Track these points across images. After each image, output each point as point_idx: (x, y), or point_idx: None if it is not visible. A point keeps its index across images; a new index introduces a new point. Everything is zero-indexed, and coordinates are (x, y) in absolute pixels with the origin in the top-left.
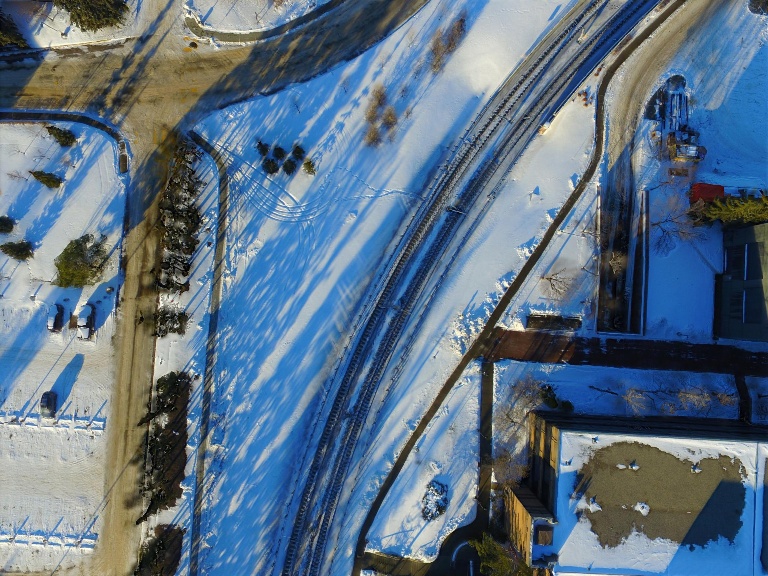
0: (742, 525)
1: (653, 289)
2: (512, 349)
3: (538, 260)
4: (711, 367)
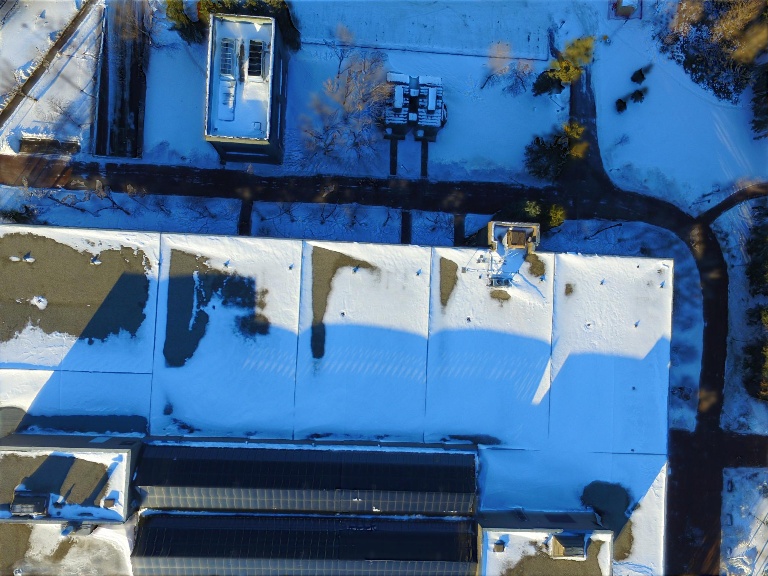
0: (145, 318)
1: (155, 112)
2: (3, 174)
3: (36, 83)
4: (218, 192)
